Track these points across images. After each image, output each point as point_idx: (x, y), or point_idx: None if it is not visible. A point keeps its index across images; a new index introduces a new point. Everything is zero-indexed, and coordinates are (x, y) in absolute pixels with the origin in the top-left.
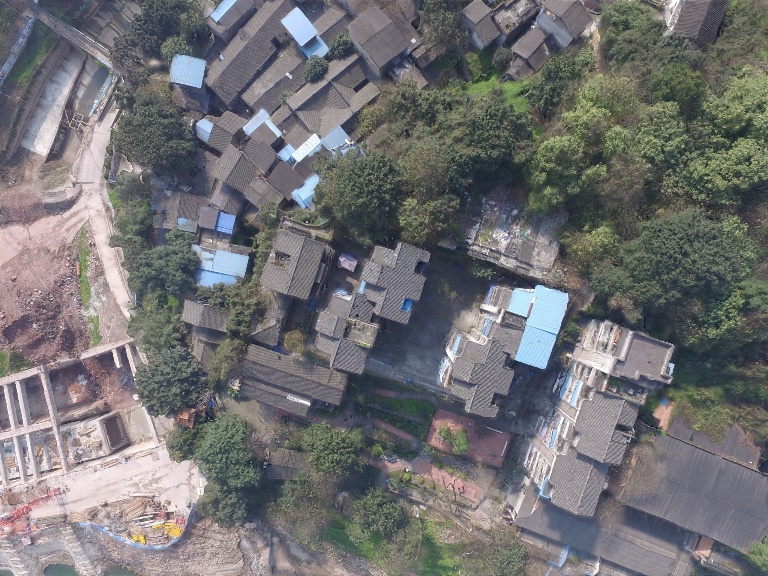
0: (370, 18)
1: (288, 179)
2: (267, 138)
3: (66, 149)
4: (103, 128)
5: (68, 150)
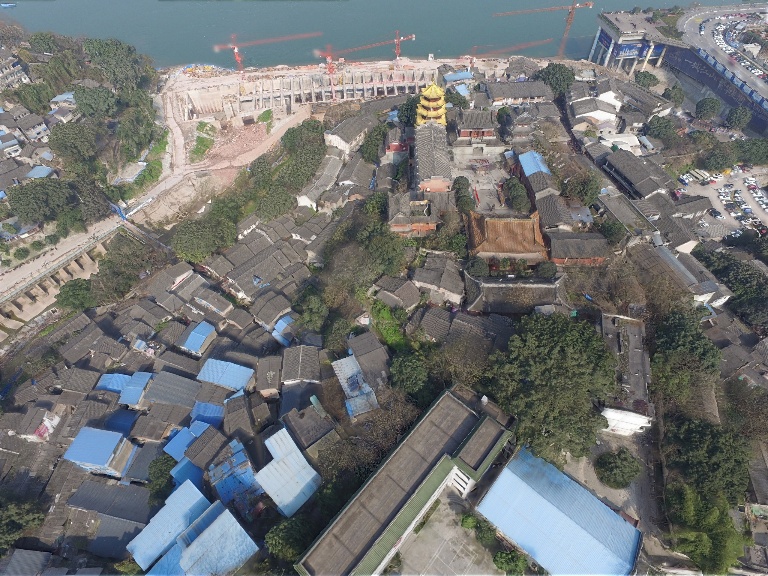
0: None
1: None
2: (5, 137)
3: None
4: (151, 196)
5: None
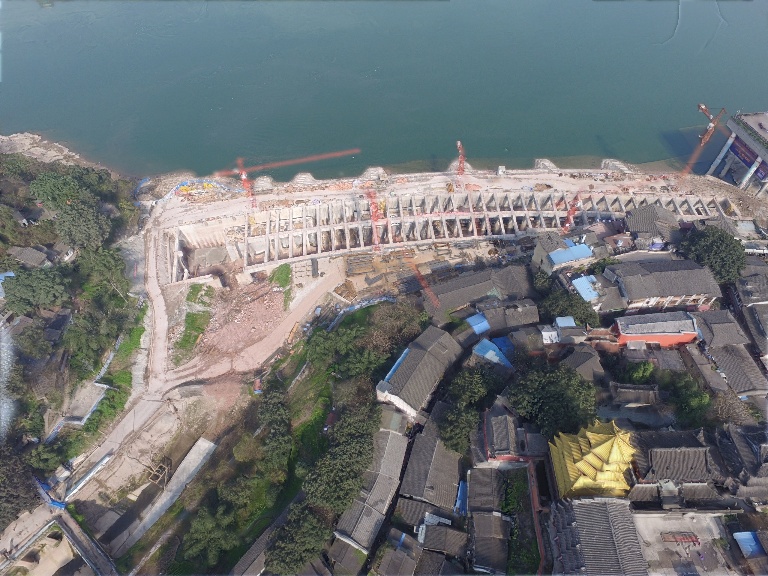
0: None
1: None
2: None
3: (188, 450)
4: (109, 447)
5: (186, 449)
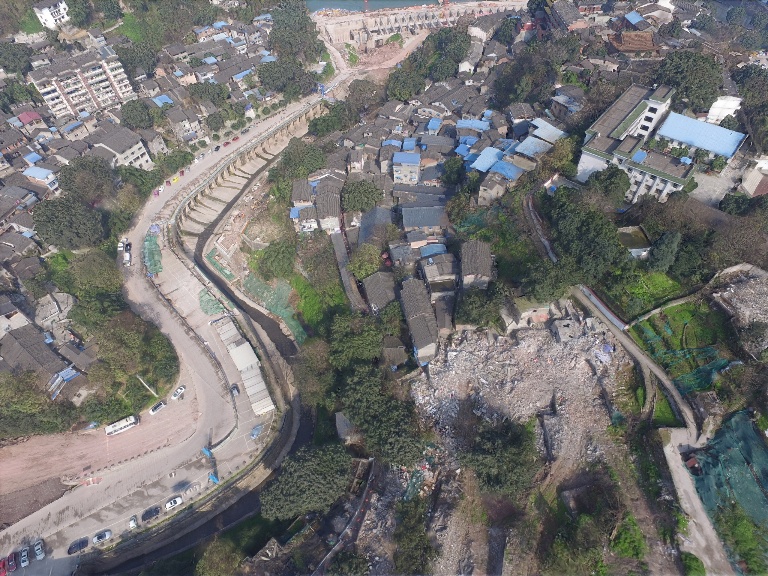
0: (175, 51)
1: (228, 26)
2: None
3: None
4: None
5: None
